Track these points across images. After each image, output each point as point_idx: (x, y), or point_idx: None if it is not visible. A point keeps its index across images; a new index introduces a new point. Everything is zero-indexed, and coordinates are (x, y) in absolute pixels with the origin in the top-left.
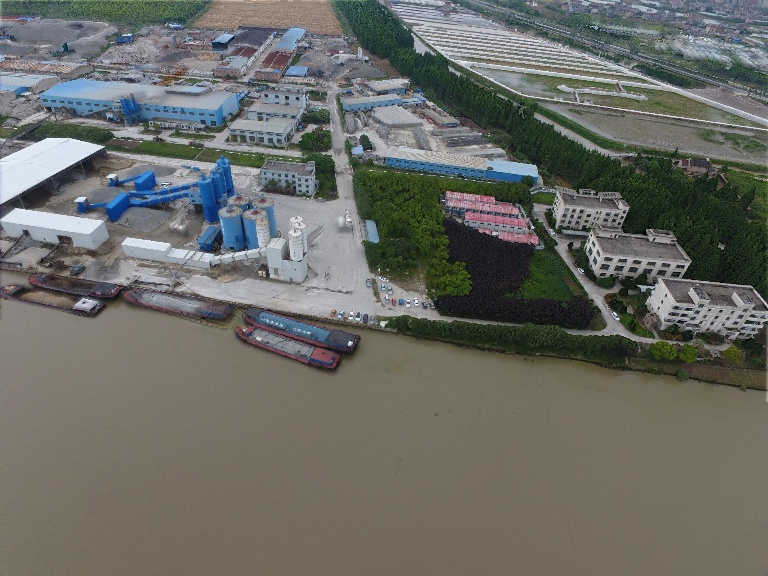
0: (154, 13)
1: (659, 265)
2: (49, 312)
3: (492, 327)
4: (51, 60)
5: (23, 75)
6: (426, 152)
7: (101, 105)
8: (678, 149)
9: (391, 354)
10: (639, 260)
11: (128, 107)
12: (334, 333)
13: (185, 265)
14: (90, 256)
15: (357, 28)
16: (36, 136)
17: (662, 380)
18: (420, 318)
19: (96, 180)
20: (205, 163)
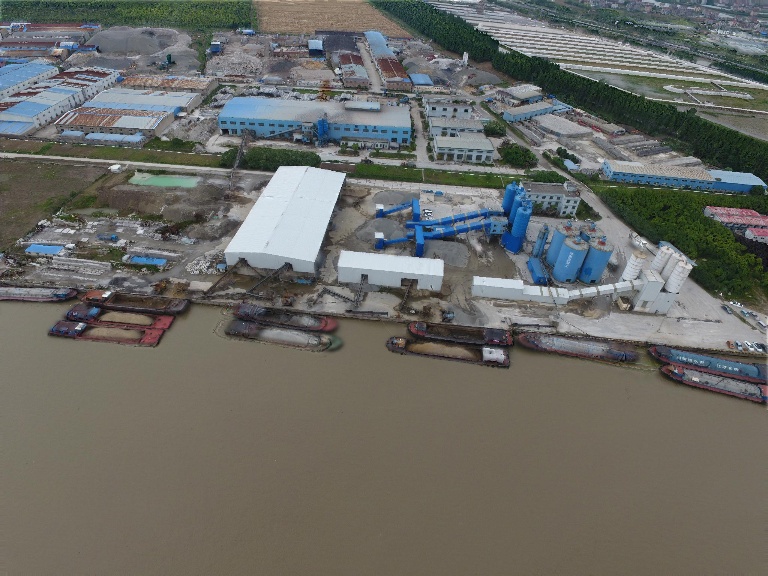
0: (211, 17)
1: None
2: (461, 365)
3: None
4: (160, 74)
5: (164, 93)
6: (644, 164)
7: (286, 125)
8: None
9: None
10: None
11: (323, 127)
12: (762, 368)
13: (539, 302)
14: (438, 298)
15: (429, 30)
16: (249, 163)
17: None
18: None
19: (353, 211)
20: (437, 186)
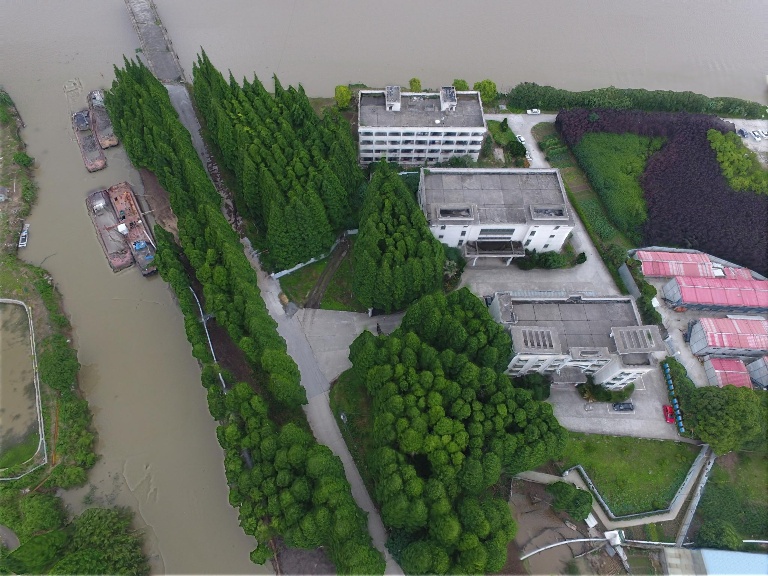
0: None
1: None
2: None
3: (666, 92)
4: None
5: None
6: None
7: None
8: None
9: (739, 87)
10: None
11: None
12: None
13: None
14: None
15: None
16: None
17: None
18: (740, 107)
19: None
20: None
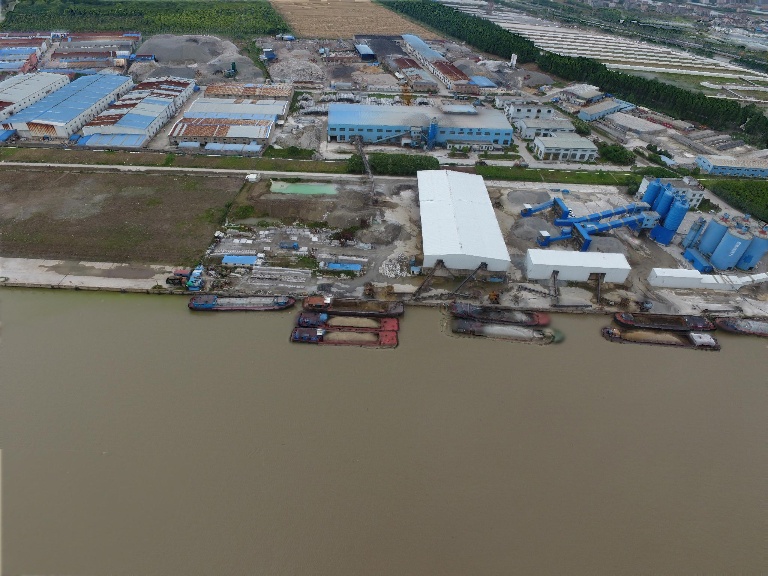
0: (243, 23)
1: None
2: (679, 351)
3: None
4: (230, 82)
5: (254, 101)
6: (736, 158)
7: (394, 131)
8: None
9: None
10: None
11: (434, 131)
12: None
13: (713, 289)
14: (624, 290)
15: (461, 32)
16: (378, 169)
17: None
18: None
19: (497, 211)
20: (558, 184)
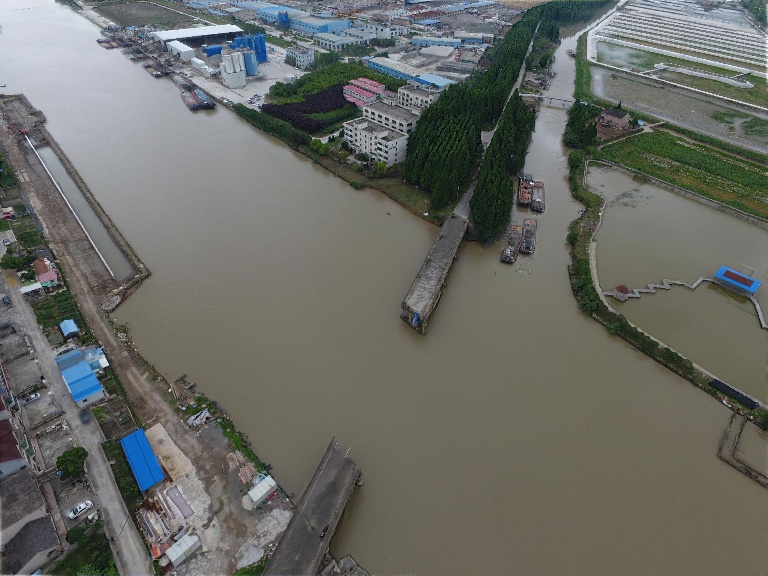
0: None
1: (391, 121)
2: (146, 73)
3: (260, 113)
4: None
5: None
6: None
7: (276, 18)
8: (654, 113)
9: None
10: (380, 114)
11: (282, 19)
12: (207, 99)
13: None
14: (182, 63)
15: None
16: None
17: (305, 159)
18: None
19: None
20: (283, 49)
